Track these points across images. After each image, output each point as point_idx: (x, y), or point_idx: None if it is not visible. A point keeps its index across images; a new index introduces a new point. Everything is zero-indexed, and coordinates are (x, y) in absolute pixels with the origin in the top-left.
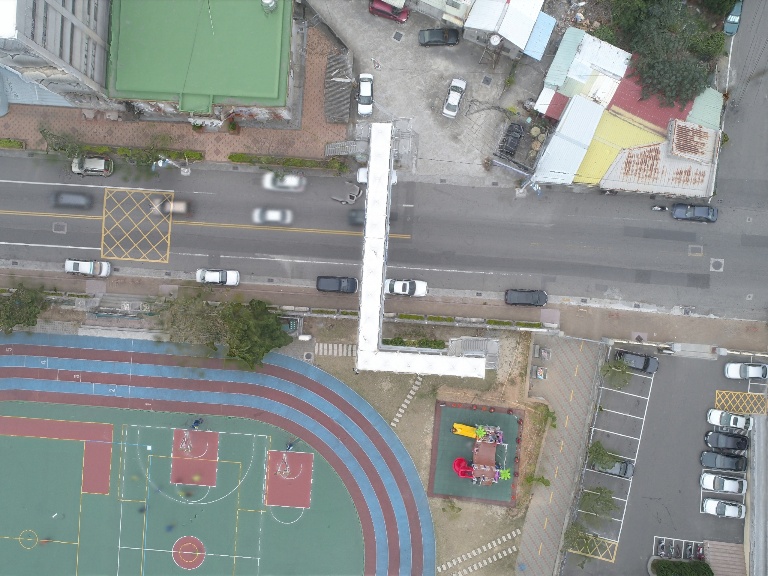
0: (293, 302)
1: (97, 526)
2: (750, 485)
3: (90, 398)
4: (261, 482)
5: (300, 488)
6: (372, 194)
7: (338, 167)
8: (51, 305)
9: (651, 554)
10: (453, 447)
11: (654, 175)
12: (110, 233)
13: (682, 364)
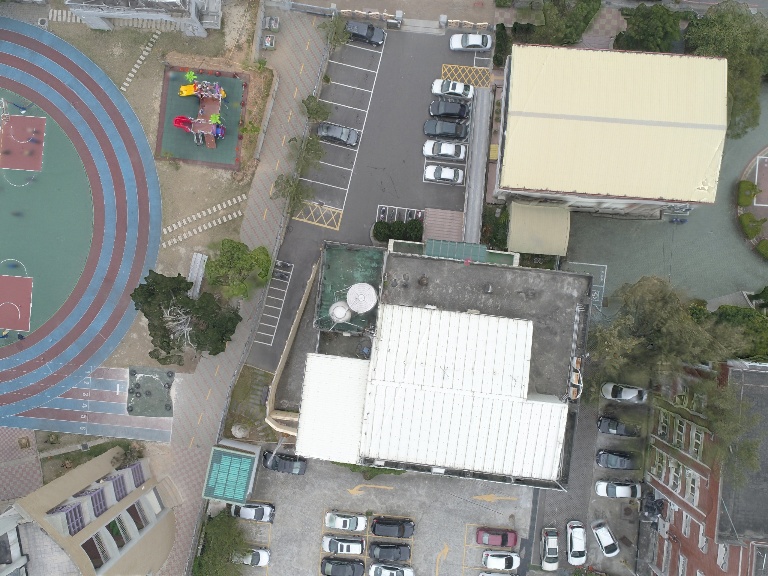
0: None
1: None
2: (469, 151)
3: None
4: None
5: (32, 152)
6: None
7: None
8: None
9: (374, 222)
10: (180, 111)
11: None
12: None
13: (410, 39)
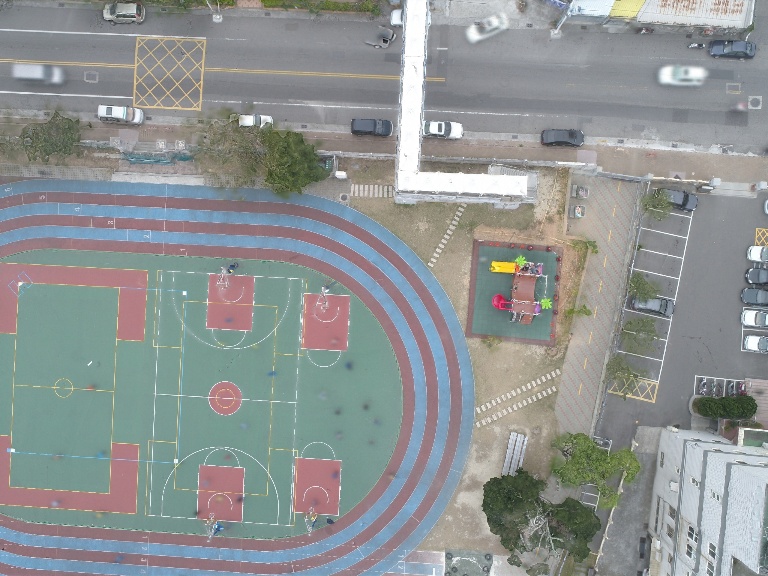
0: (327, 147)
1: (133, 373)
2: None
3: (124, 244)
4: (298, 326)
5: (337, 331)
6: (411, 11)
7: (371, 9)
8: (84, 153)
9: (692, 393)
10: (491, 286)
11: (692, 6)
12: (142, 81)
13: (721, 203)
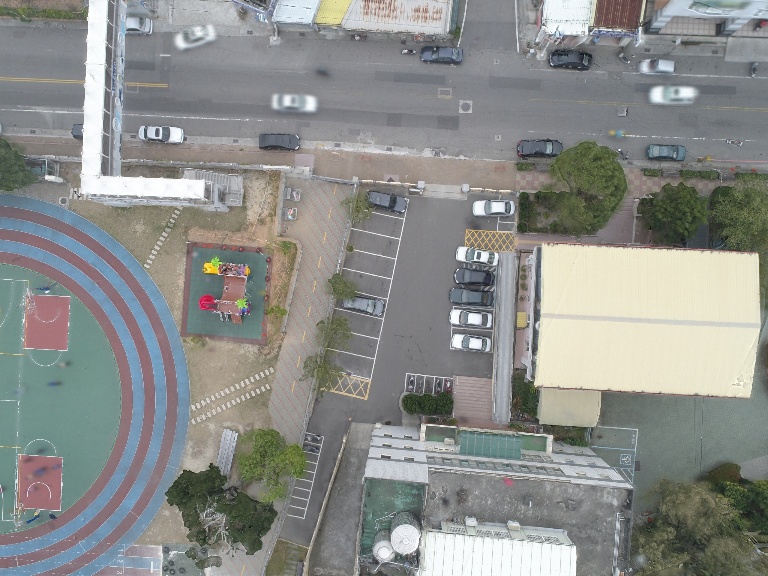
0: (54, 152)
1: None
2: (496, 319)
3: None
4: (20, 326)
5: (58, 331)
6: (91, 20)
7: None
8: None
9: (403, 391)
10: (205, 287)
11: (393, 13)
12: None
13: (433, 204)
